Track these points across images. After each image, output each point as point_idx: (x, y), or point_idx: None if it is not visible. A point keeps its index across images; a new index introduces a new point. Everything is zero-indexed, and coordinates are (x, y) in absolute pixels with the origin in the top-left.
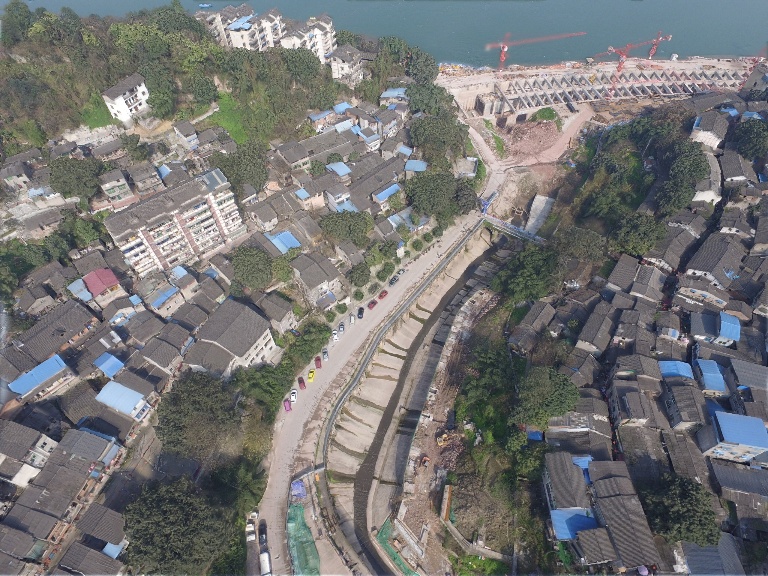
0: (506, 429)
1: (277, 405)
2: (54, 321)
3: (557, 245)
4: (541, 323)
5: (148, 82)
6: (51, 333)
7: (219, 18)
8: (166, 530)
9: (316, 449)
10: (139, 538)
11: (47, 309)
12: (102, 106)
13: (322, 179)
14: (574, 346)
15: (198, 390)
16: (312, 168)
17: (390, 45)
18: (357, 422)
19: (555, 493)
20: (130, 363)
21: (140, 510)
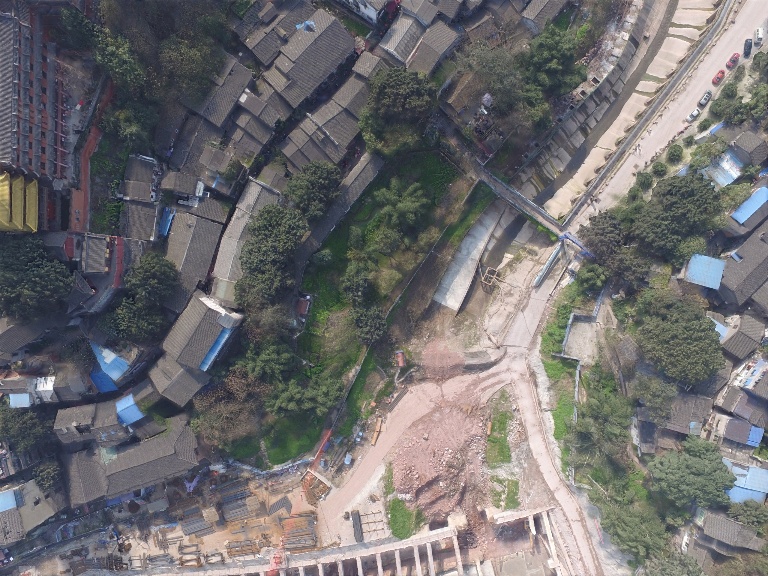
0: None
1: None
2: None
3: None
4: None
5: None
6: None
7: None
8: None
9: None
10: None
11: None
12: None
13: None
14: None
15: None
16: None
17: None
18: None
19: None
20: None
21: None
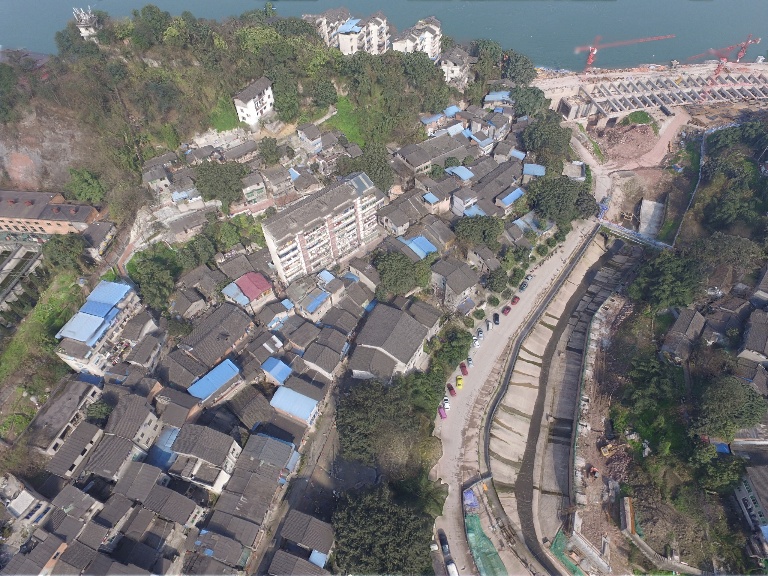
0: (683, 440)
1: (436, 412)
2: (217, 325)
3: (700, 252)
4: (694, 331)
5: (276, 86)
6: (216, 337)
7: (325, 21)
8: (382, 540)
9: (478, 457)
10: (355, 548)
11: (199, 313)
12: (229, 109)
13: (443, 183)
14: (735, 355)
15: (380, 397)
16: (432, 172)
17: (486, 48)
18: (507, 430)
19: (767, 509)
20: (293, 368)
21: (353, 519)
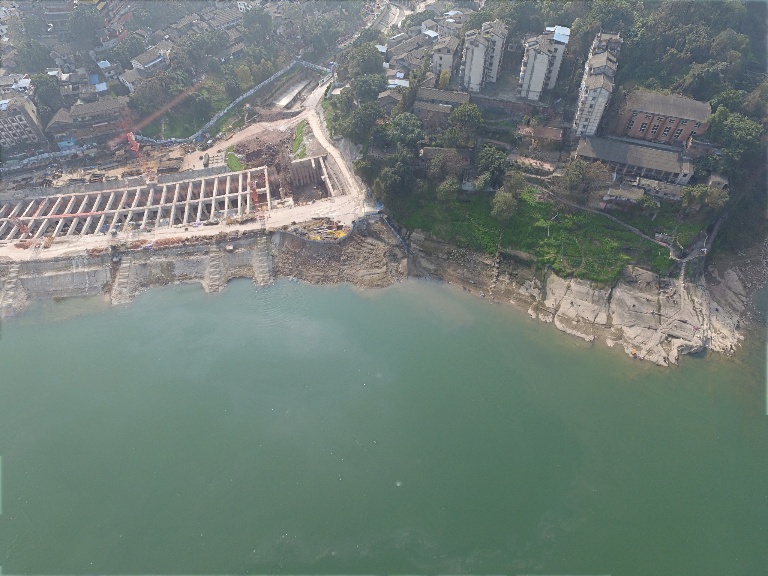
0: None
1: None
2: None
3: None
4: None
5: None
6: None
7: (595, 44)
8: None
9: None
10: None
11: None
12: None
13: None
14: None
15: None
16: None
17: None
18: None
19: None
20: None
21: None
